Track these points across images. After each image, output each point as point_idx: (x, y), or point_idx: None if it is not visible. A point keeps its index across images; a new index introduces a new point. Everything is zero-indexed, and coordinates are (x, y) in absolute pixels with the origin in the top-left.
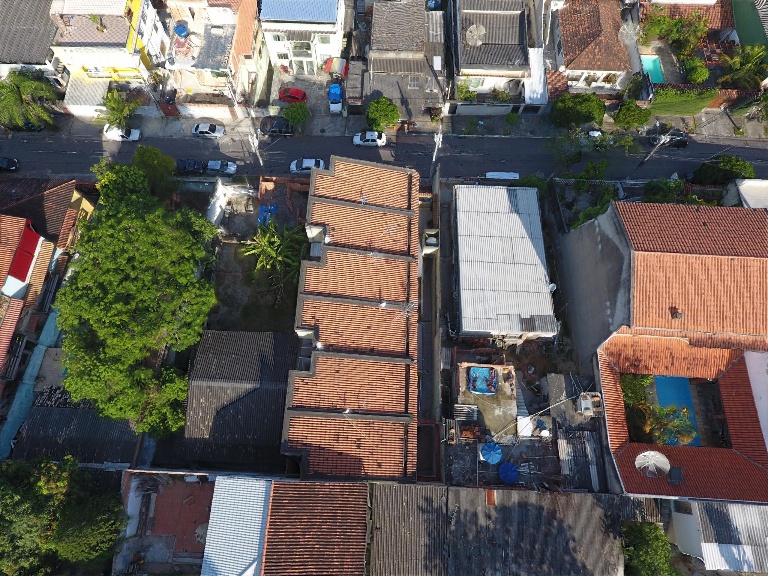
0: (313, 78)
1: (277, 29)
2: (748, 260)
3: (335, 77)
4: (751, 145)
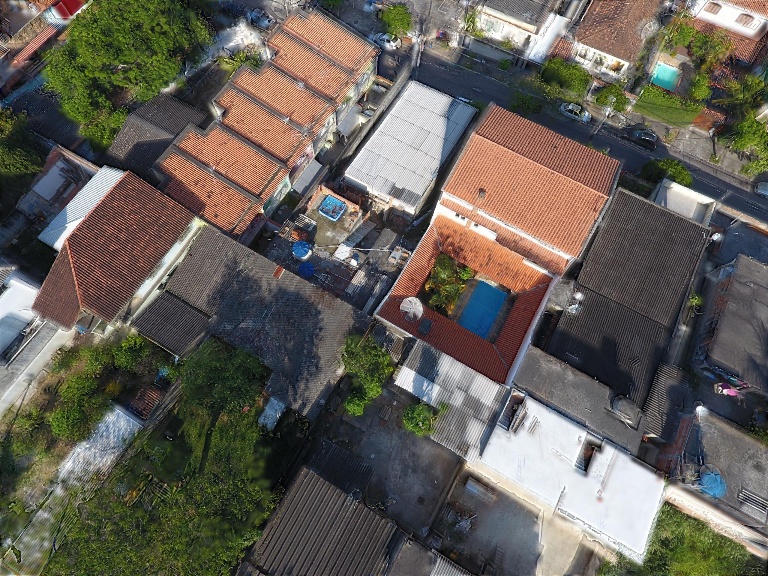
0: None
1: None
2: (566, 179)
3: None
4: (719, 175)
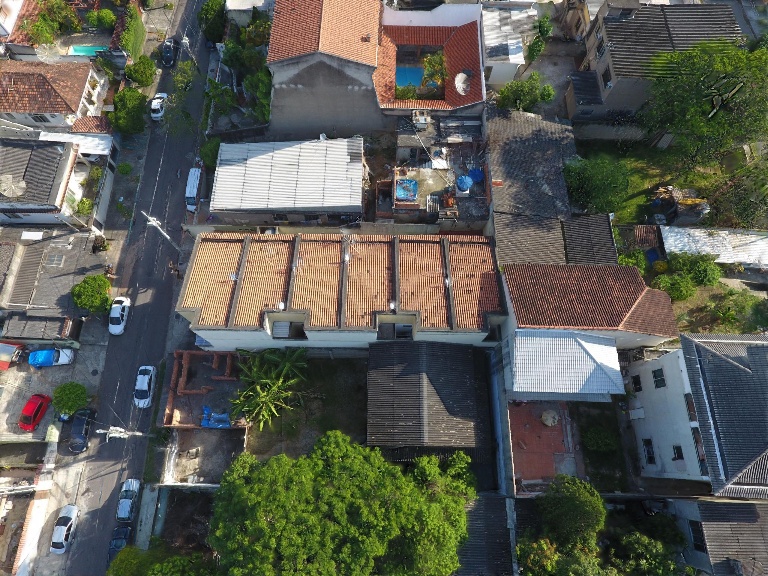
0: (8, 390)
1: None
2: None
3: (17, 358)
4: (184, 2)
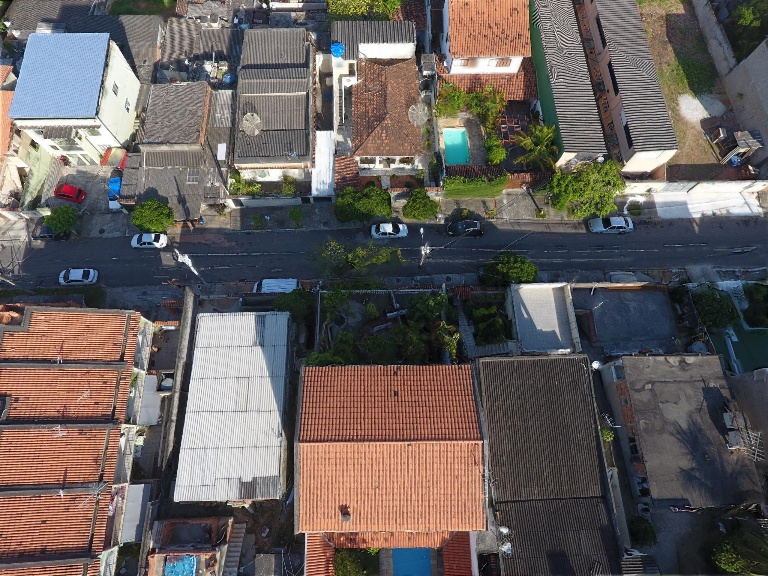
0: (96, 169)
1: (34, 125)
2: (427, 444)
3: (116, 169)
4: (552, 229)
